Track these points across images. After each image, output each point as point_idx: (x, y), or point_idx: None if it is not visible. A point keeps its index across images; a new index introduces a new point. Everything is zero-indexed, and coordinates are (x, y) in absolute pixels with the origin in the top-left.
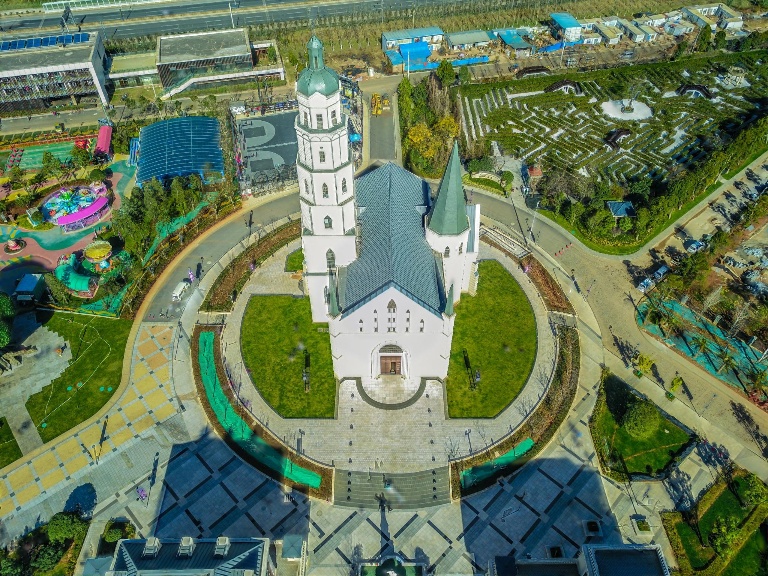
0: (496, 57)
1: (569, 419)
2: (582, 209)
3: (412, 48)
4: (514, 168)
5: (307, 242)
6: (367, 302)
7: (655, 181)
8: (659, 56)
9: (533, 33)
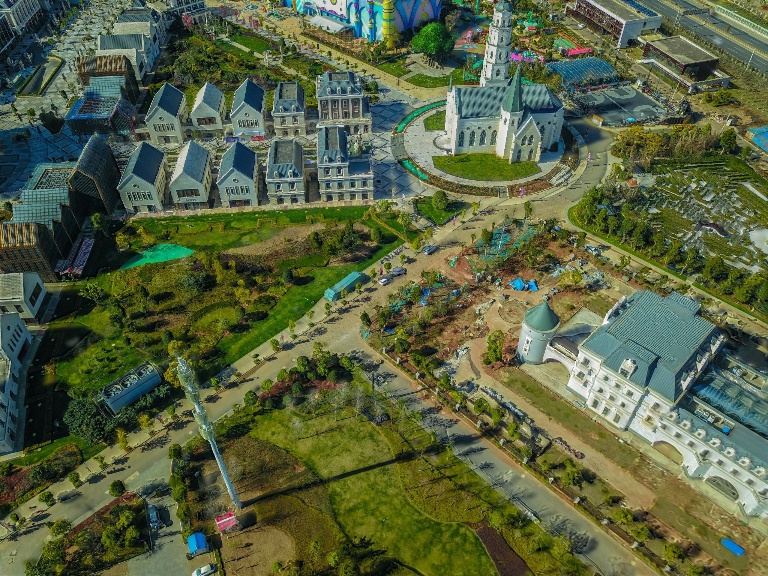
0: None
1: None
2: (592, 192)
3: None
4: (643, 183)
5: None
6: None
7: (647, 228)
8: None
9: None
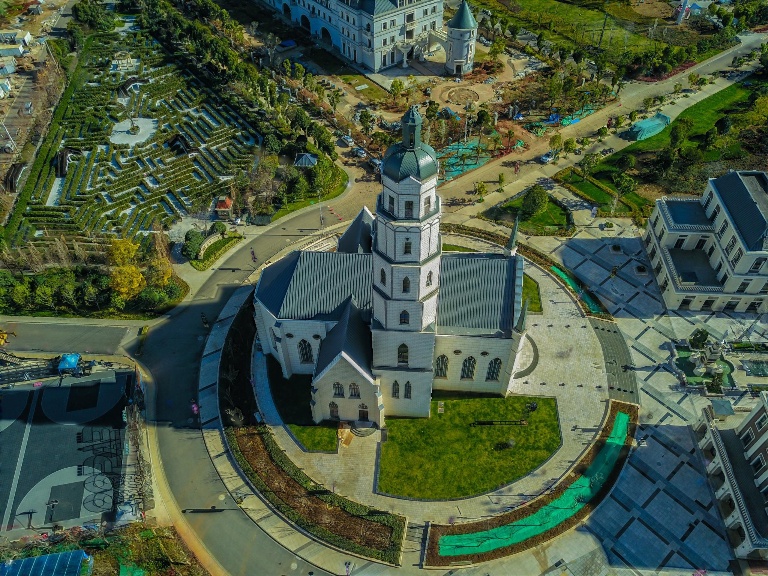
0: None
1: None
2: (304, 180)
3: None
4: None
5: None
6: None
7: None
8: None
9: None
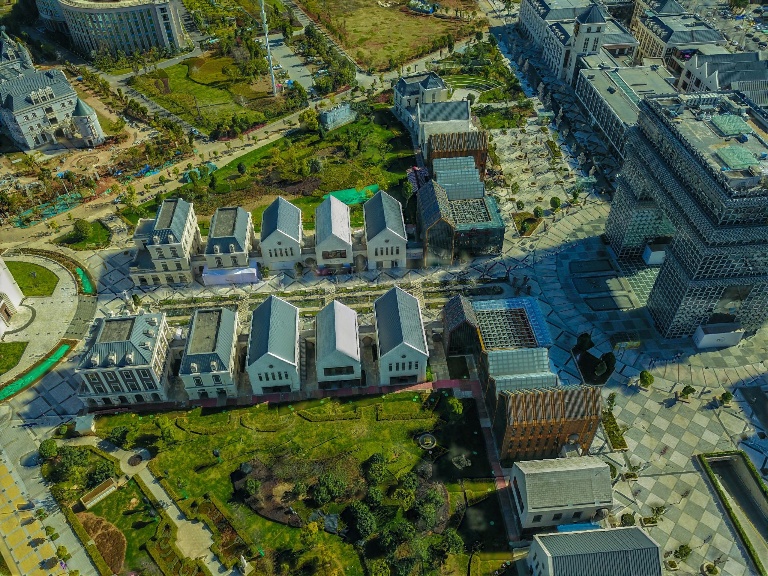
0: None
1: None
2: None
3: None
4: None
5: None
6: None
7: None
8: None
9: None
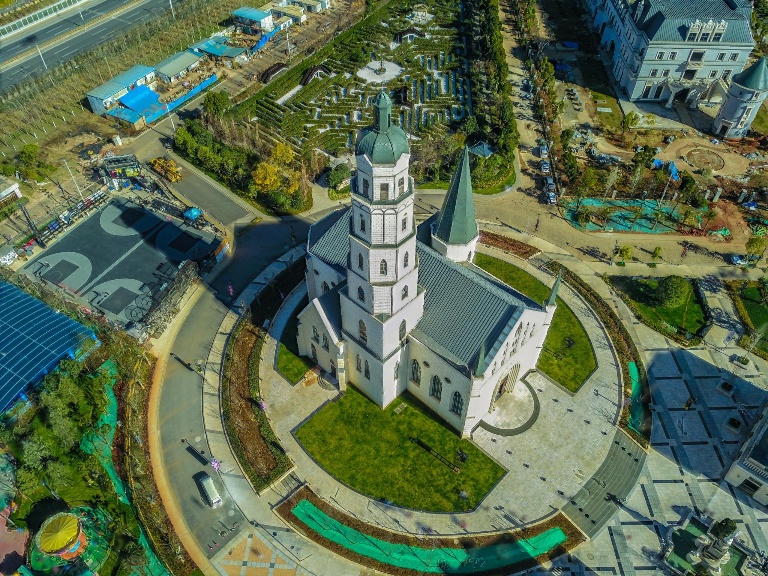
0: (222, 72)
1: (627, 328)
2: None
3: (135, 97)
4: None
5: (385, 327)
6: (505, 340)
7: (476, 117)
8: (349, 18)
9: (226, 37)
